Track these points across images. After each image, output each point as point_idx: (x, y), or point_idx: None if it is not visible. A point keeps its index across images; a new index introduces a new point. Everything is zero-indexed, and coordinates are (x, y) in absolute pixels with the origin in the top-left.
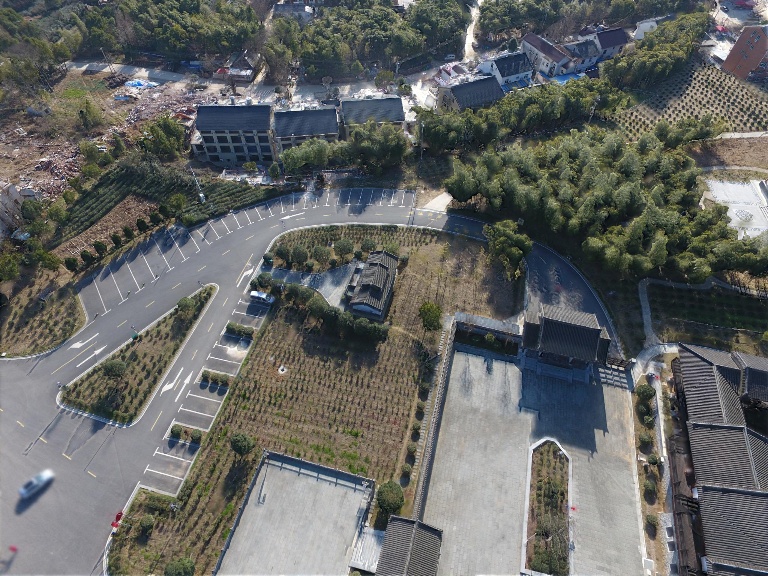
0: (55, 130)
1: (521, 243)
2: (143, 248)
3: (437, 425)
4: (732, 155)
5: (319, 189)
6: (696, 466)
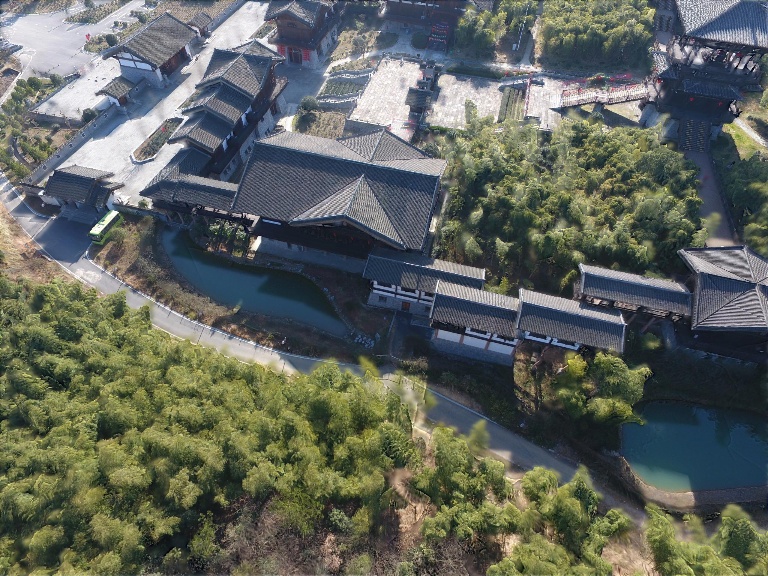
0: None
1: None
2: None
3: (230, 15)
4: None
5: None
6: None
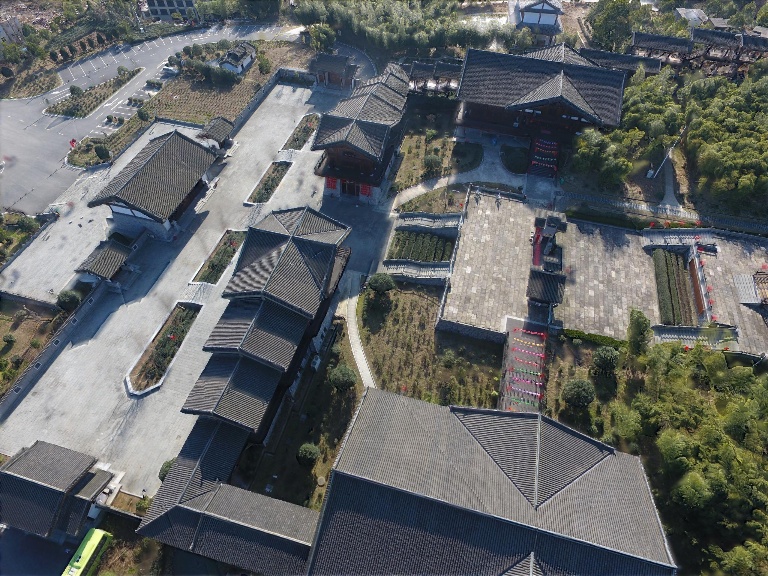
0: (47, 5)
1: (327, 33)
2: (101, 54)
3: (255, 109)
4: (503, 8)
5: (220, 27)
6: None
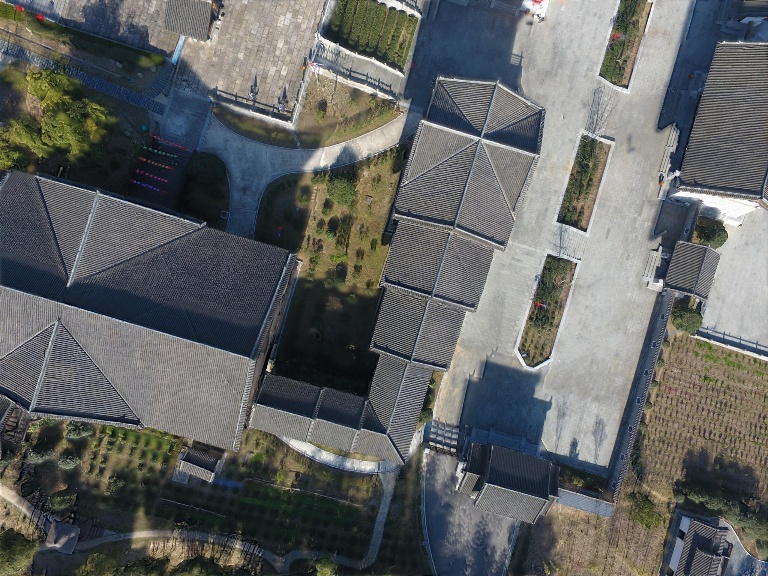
0: None
1: None
2: None
3: (636, 385)
4: None
5: None
6: (460, 328)
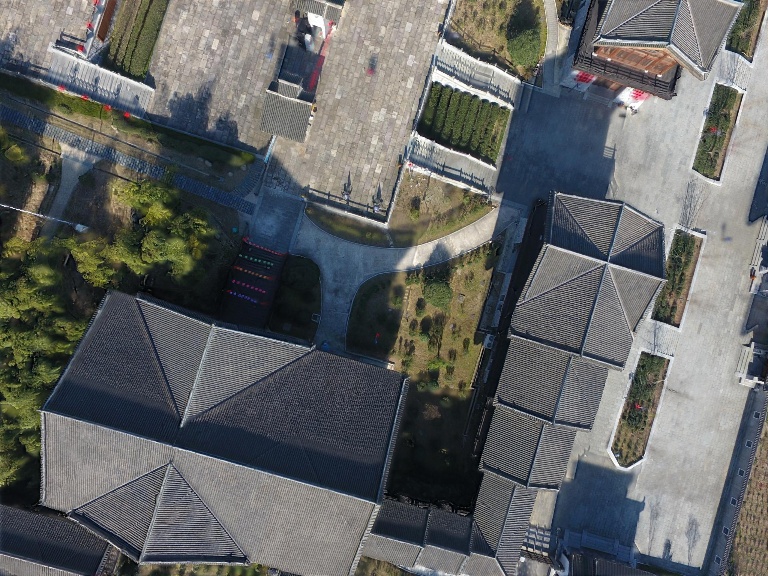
0: None
1: None
2: None
3: (729, 483)
4: None
5: None
6: None
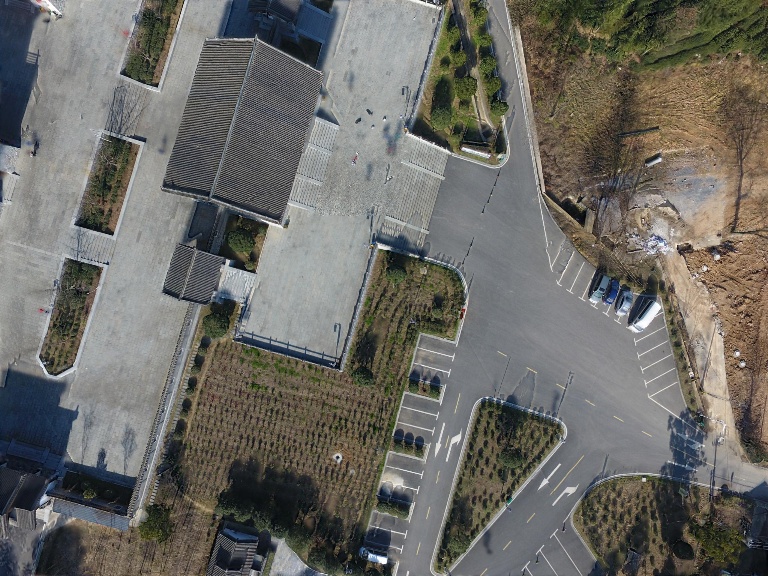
0: None
1: None
2: None
3: None
4: None
5: None
6: None
